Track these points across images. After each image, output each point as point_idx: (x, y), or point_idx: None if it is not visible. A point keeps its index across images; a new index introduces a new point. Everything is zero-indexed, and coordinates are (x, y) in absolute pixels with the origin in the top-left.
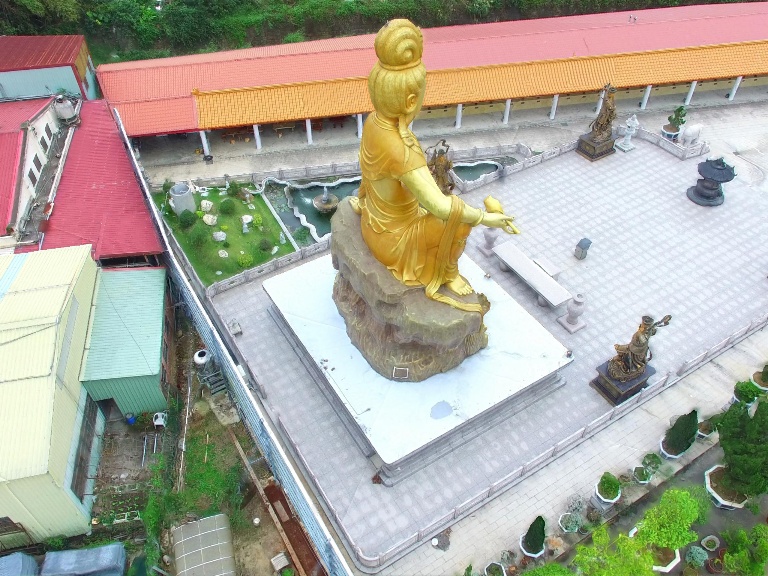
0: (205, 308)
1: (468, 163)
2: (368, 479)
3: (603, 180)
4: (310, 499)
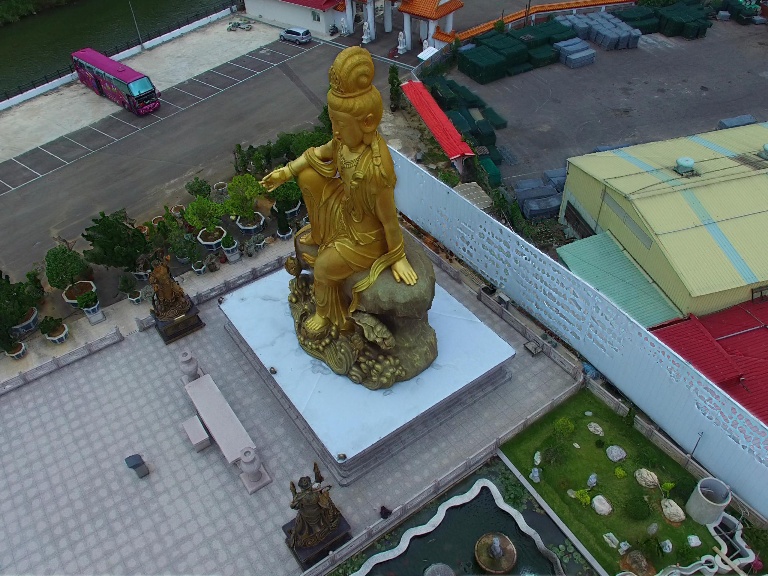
0: None
1: None
2: None
3: None
4: None
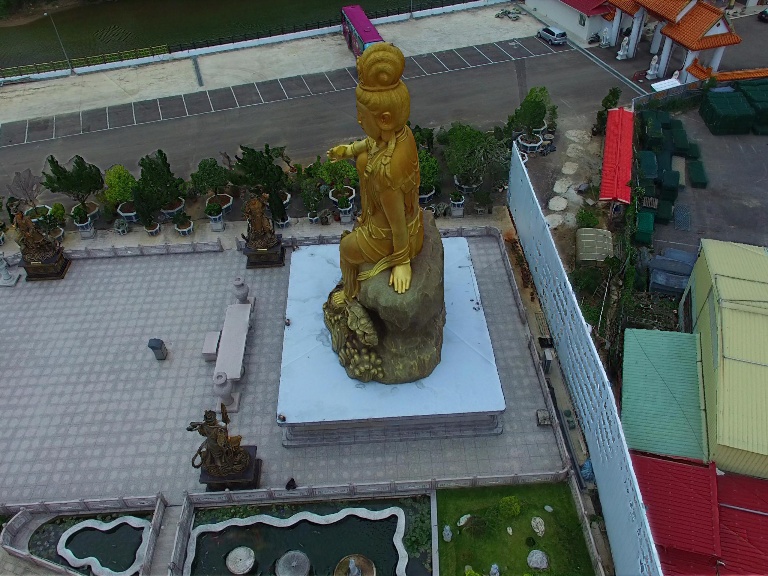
0: (574, 467)
1: (94, 569)
2: (475, 270)
3: (2, 440)
4: (530, 184)
